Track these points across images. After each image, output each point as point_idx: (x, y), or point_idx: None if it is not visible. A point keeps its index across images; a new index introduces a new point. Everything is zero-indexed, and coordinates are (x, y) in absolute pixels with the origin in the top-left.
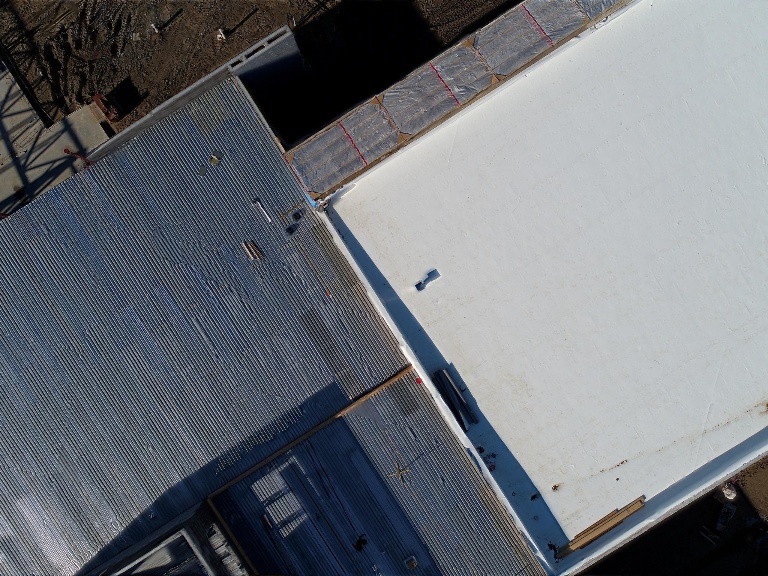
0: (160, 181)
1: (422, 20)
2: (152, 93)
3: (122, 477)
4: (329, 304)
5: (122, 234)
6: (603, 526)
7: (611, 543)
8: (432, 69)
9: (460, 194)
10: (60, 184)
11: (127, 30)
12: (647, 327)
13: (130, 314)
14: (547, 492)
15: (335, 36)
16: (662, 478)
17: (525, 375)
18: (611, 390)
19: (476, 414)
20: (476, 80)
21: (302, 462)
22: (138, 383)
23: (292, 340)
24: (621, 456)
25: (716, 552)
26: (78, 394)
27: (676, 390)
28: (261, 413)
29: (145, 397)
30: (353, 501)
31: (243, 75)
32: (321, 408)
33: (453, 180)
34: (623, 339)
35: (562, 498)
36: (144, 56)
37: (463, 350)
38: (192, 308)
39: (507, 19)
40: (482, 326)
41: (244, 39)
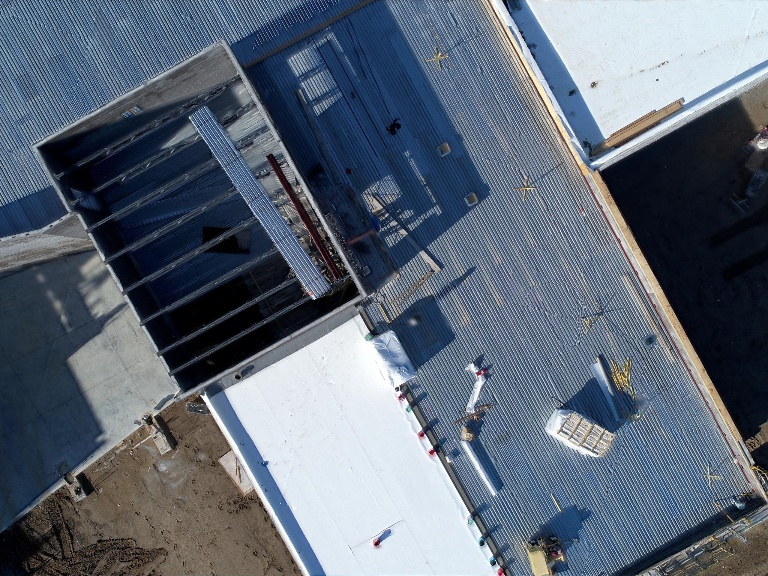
0: None
1: None
2: None
3: (158, 45)
4: None
5: None
6: (640, 124)
7: (649, 133)
8: None
9: None
10: None
11: None
12: None
13: None
14: (586, 88)
15: None
16: (702, 82)
17: None
18: None
19: None
20: None
21: (341, 40)
22: None
23: None
24: (662, 56)
25: (745, 222)
26: None
27: None
28: None
29: None
30: (390, 84)
31: None
32: None
33: None
34: None
35: (600, 95)
36: None
37: None
38: None
39: None
40: None
41: None
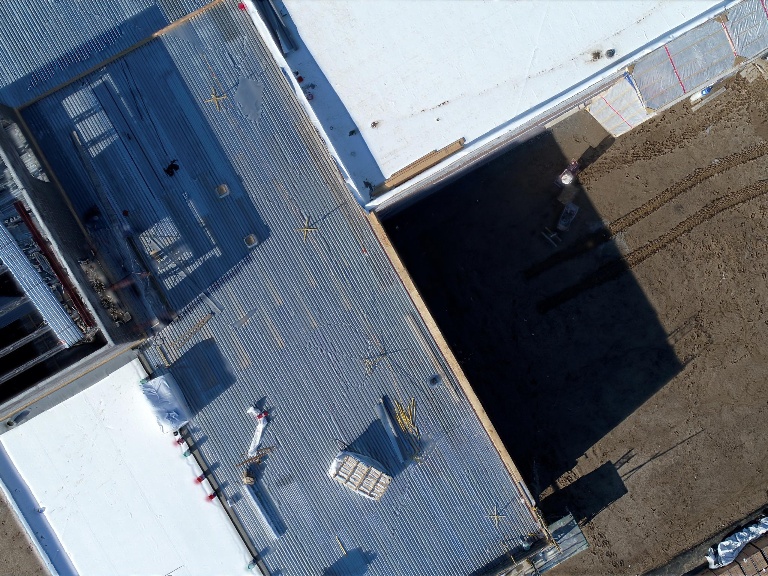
0: None
1: None
2: None
3: None
4: None
5: None
6: (420, 165)
7: (424, 174)
8: None
9: None
10: None
11: None
12: None
13: None
14: (366, 128)
15: None
16: (483, 121)
17: (348, 4)
18: (435, 27)
19: (296, 40)
20: None
21: (116, 81)
22: None
23: None
24: (443, 96)
25: (558, 256)
26: None
27: (501, 31)
28: (78, 31)
29: None
30: (167, 124)
31: None
32: (140, 30)
33: None
34: None
35: (381, 135)
36: None
37: None
38: None
39: None
40: None
41: None
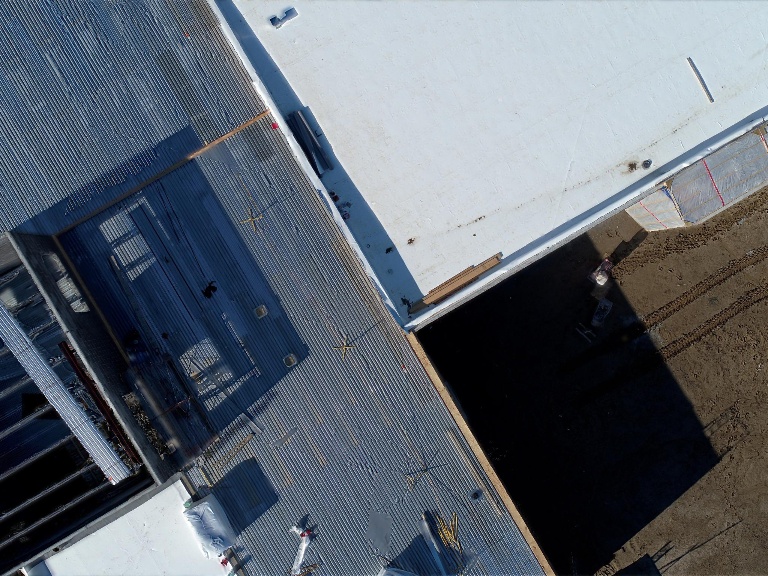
0: None
1: None
2: None
3: None
4: (187, 46)
5: None
6: (458, 281)
7: (462, 293)
8: None
9: None
10: None
11: None
12: (508, 78)
13: None
14: (403, 245)
15: None
16: (520, 236)
17: (383, 122)
18: (470, 142)
19: (331, 160)
20: None
21: (153, 204)
22: None
23: (148, 81)
24: (479, 211)
25: (592, 351)
26: None
27: (537, 145)
28: (113, 154)
29: None
30: (204, 246)
31: None
32: (175, 152)
33: None
34: (484, 90)
35: (418, 252)
36: None
37: (320, 93)
38: (46, 43)
39: None
40: (340, 69)
41: None
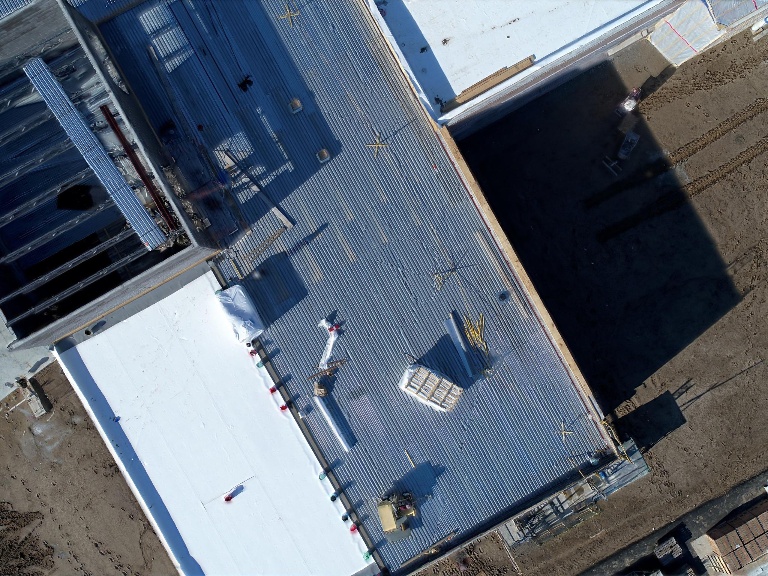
0: None
1: None
2: None
3: (11, 3)
4: None
5: None
6: (491, 81)
7: (496, 88)
8: None
9: None
10: None
11: None
12: None
13: None
14: (437, 45)
15: None
16: (553, 39)
17: None
18: None
19: None
20: None
21: None
22: None
23: None
24: (513, 14)
25: (618, 185)
26: None
27: None
28: None
29: None
30: (241, 41)
31: None
32: None
33: None
34: None
35: (452, 52)
36: None
37: None
38: None
39: None
40: None
41: None
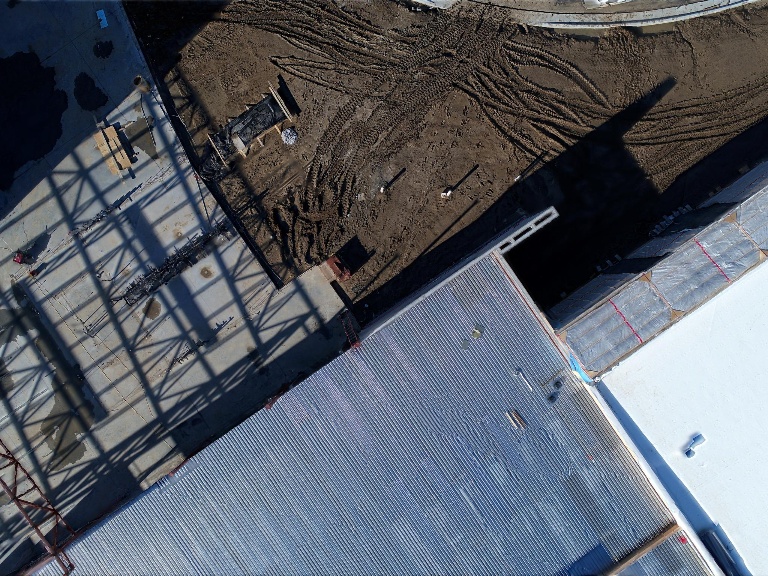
0: (425, 356)
1: (637, 170)
2: (379, 251)
3: None
4: (592, 469)
5: (390, 410)
6: None
7: None
8: (698, 245)
9: (722, 360)
10: (329, 364)
11: (352, 191)
12: None
13: (400, 488)
14: None
15: (553, 188)
16: None
17: None
18: None
19: (745, 573)
20: (743, 256)
21: None
22: (410, 555)
23: (558, 506)
24: None
25: None
26: (352, 569)
27: None
28: None
29: (417, 569)
30: None
31: (506, 253)
32: (588, 571)
33: (715, 347)
34: None
35: None
36: (370, 215)
37: (729, 511)
38: (460, 479)
39: (767, 194)
40: (747, 487)
41: (466, 195)
